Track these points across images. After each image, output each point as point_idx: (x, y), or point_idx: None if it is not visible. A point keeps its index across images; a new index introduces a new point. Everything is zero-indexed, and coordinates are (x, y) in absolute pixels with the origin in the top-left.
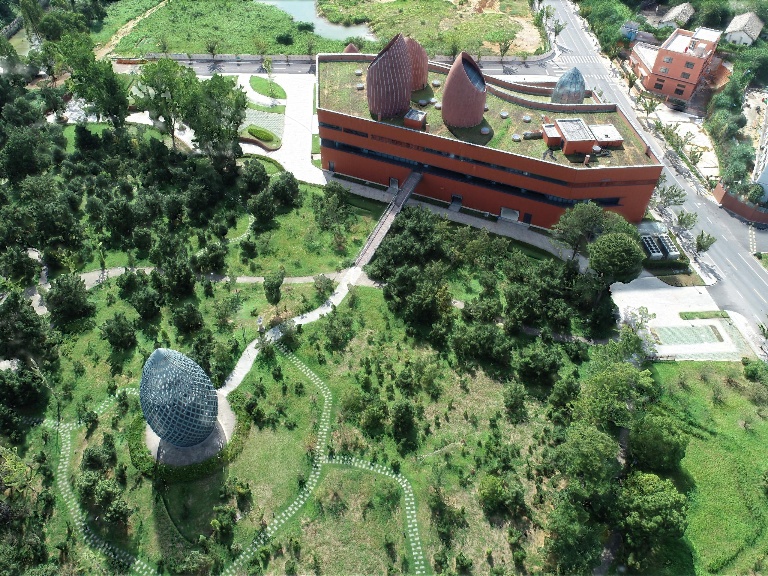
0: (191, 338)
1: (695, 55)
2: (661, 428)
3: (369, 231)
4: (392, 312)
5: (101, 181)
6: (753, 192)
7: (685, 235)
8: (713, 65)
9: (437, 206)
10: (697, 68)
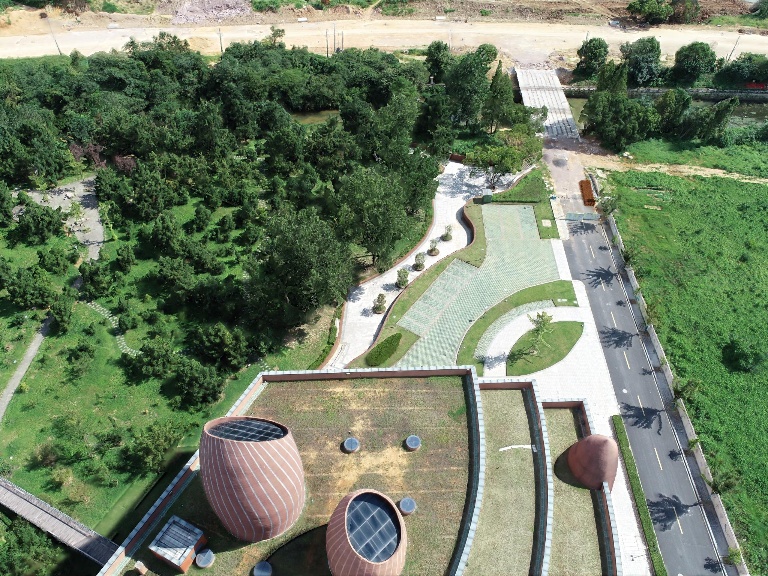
0: None
1: None
2: None
3: (79, 504)
4: None
5: (245, 210)
6: None
7: None
8: None
9: None
10: None
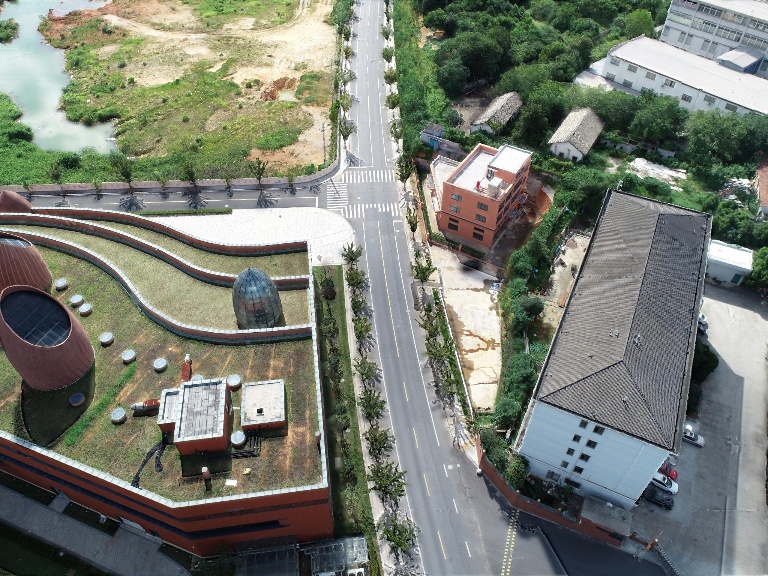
0: None
1: (487, 195)
2: None
3: None
4: None
5: None
6: (511, 473)
7: None
8: (532, 189)
9: (33, 501)
10: (492, 211)
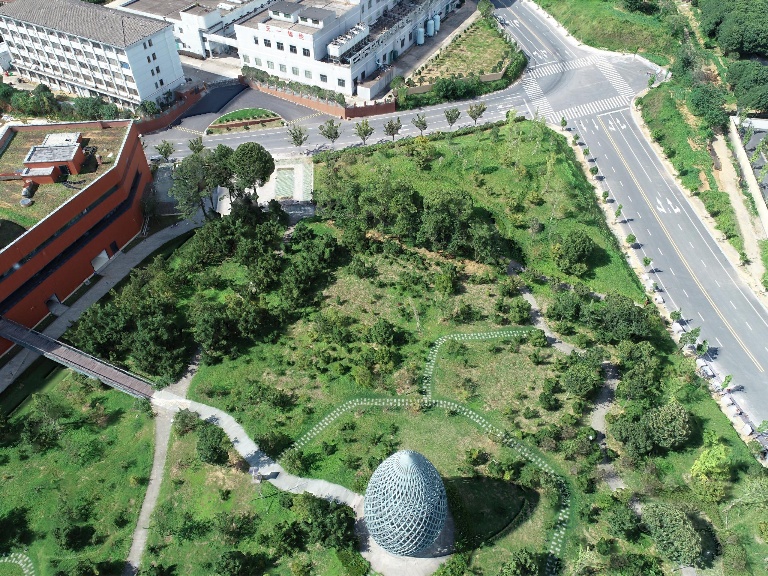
0: (263, 568)
1: None
2: (402, 185)
3: None
4: (239, 357)
5: None
6: (151, 107)
7: (171, 161)
8: None
9: (49, 326)
10: None
